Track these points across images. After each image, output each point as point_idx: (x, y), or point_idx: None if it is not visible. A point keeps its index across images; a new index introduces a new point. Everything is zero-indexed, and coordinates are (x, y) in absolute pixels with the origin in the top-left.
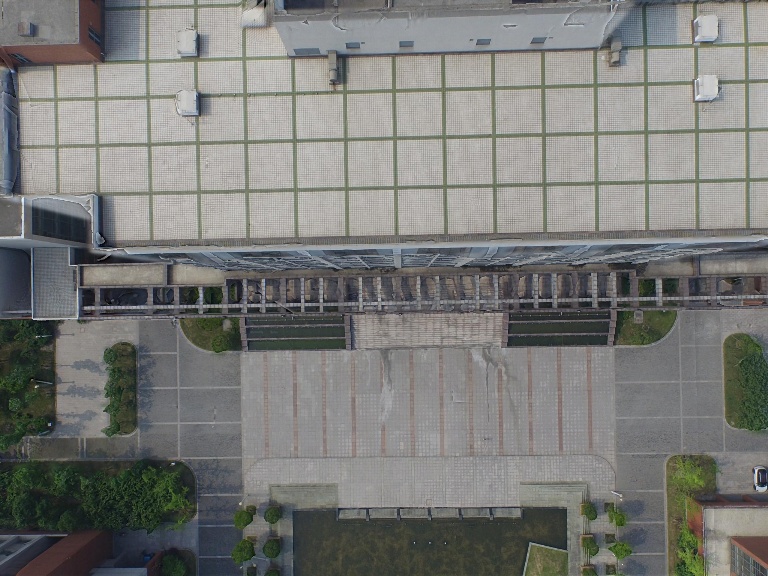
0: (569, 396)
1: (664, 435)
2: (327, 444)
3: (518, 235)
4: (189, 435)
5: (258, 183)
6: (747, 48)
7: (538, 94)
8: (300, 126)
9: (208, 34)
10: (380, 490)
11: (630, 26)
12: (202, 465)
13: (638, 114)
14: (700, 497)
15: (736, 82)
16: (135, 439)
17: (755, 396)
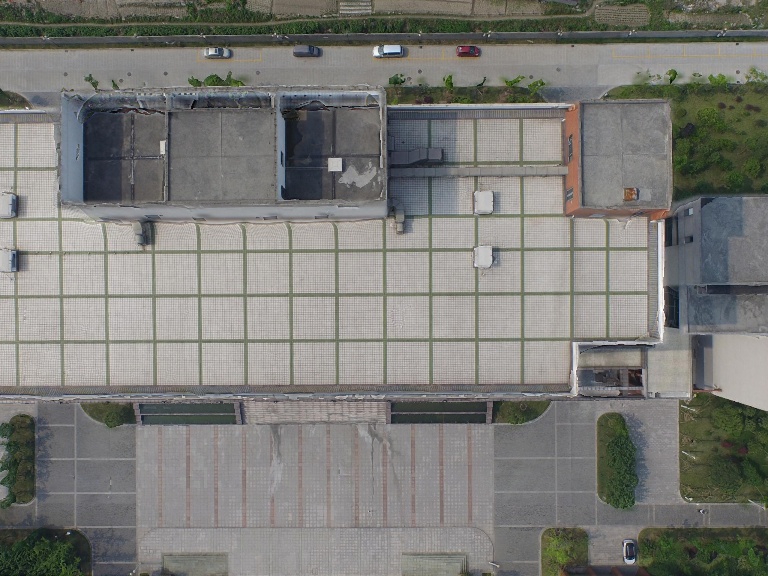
0: (450, 471)
1: (540, 509)
2: (218, 515)
3: (313, 387)
4: (85, 505)
5: (72, 335)
6: (523, 219)
7: (332, 257)
8: (112, 283)
9: (26, 195)
10: (268, 559)
11: (417, 196)
12: (98, 534)
13: (423, 277)
14: (571, 569)
15: (513, 250)
16: (33, 508)
17: (620, 476)
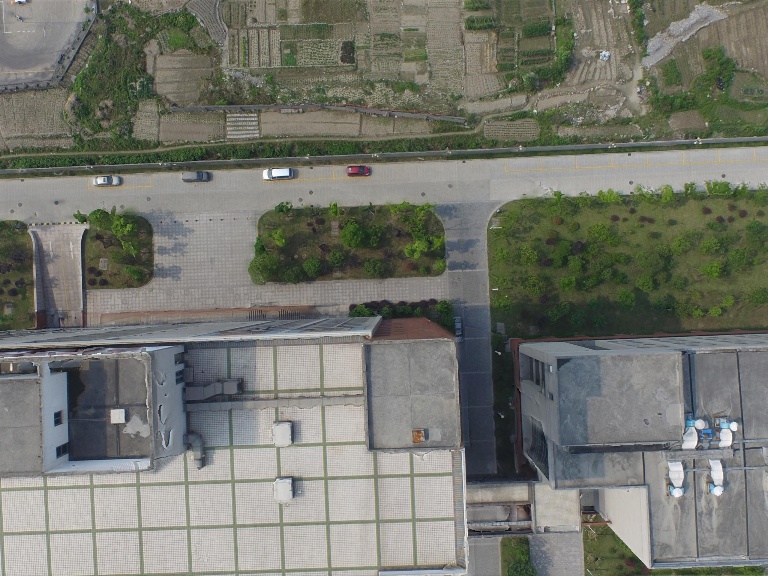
0: None
1: None
2: None
3: None
4: None
5: None
6: (325, 447)
7: (134, 491)
8: None
9: None
10: None
11: (217, 427)
12: None
13: (227, 509)
14: None
15: (316, 479)
16: None
17: None
